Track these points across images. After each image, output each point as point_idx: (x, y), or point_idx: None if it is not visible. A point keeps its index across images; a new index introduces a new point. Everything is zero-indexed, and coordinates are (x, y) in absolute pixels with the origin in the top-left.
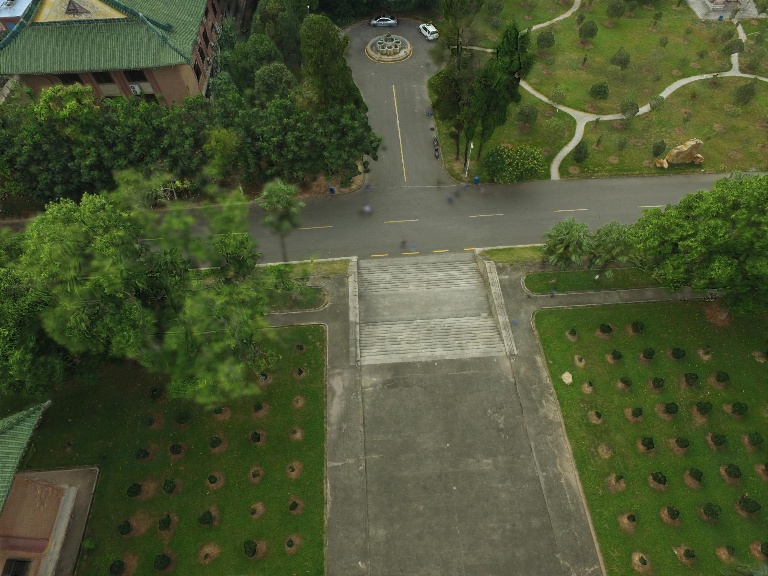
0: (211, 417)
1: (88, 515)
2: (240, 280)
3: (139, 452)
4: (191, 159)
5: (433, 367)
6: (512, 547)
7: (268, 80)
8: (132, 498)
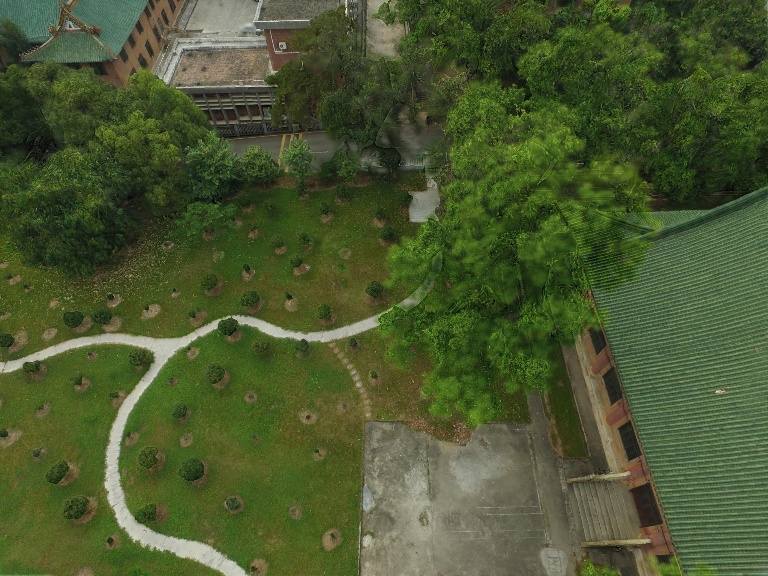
0: None
1: None
2: None
3: None
4: (695, 61)
5: None
6: None
7: (719, 5)
8: None
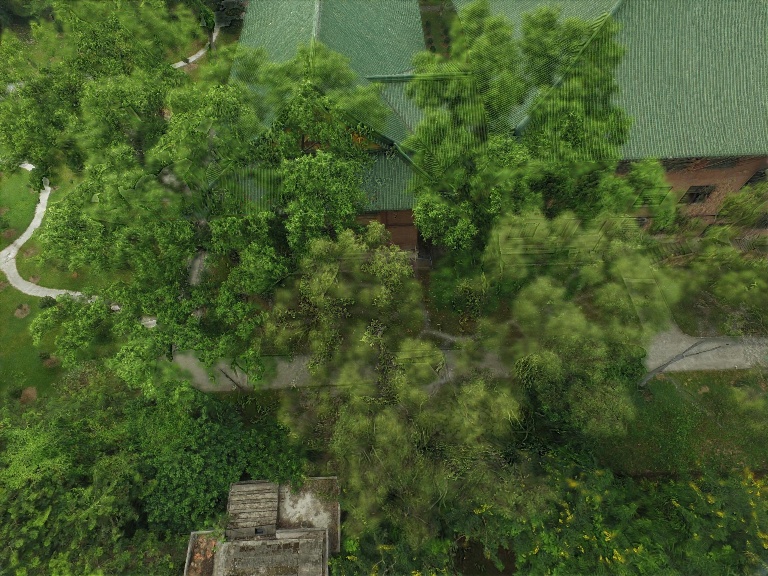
0: (459, 35)
1: None
2: None
3: (430, 38)
4: None
5: None
6: None
7: None
8: (429, 57)
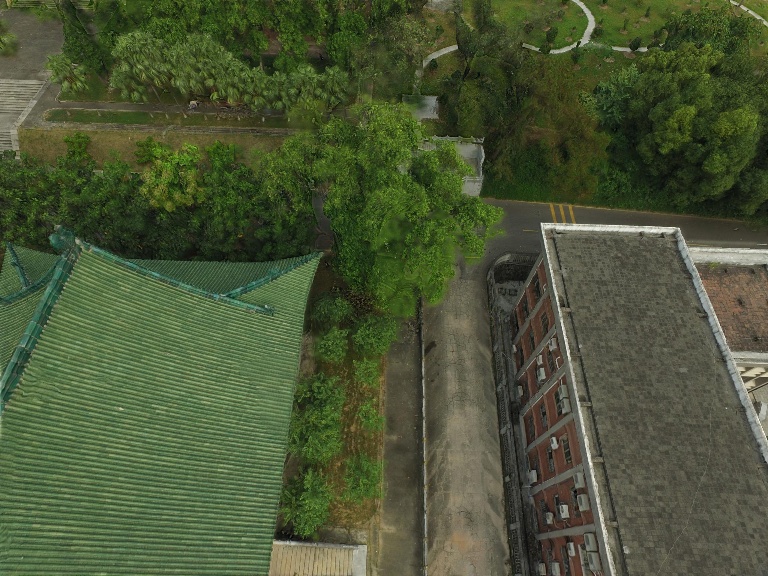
0: None
1: None
2: (103, 126)
3: None
4: None
5: (1, 76)
6: (20, 19)
7: None
8: None
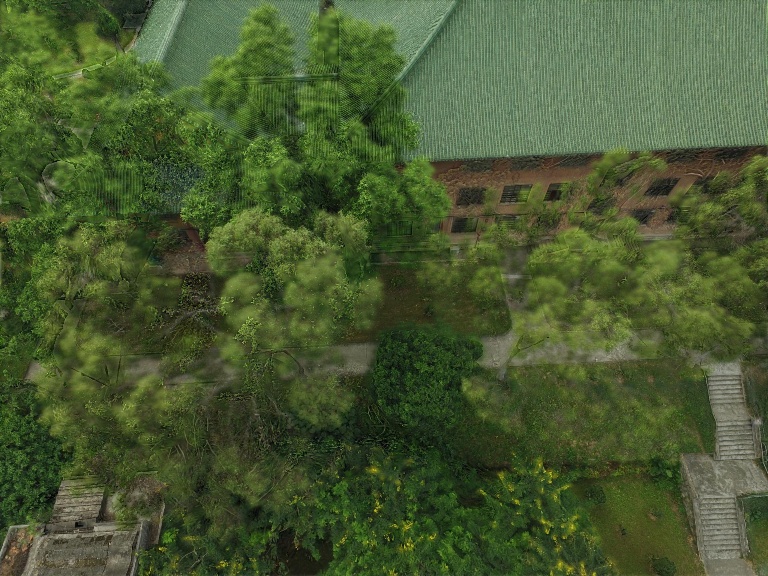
0: None
1: (324, 63)
2: None
3: None
4: None
5: None
6: None
7: None
8: None
